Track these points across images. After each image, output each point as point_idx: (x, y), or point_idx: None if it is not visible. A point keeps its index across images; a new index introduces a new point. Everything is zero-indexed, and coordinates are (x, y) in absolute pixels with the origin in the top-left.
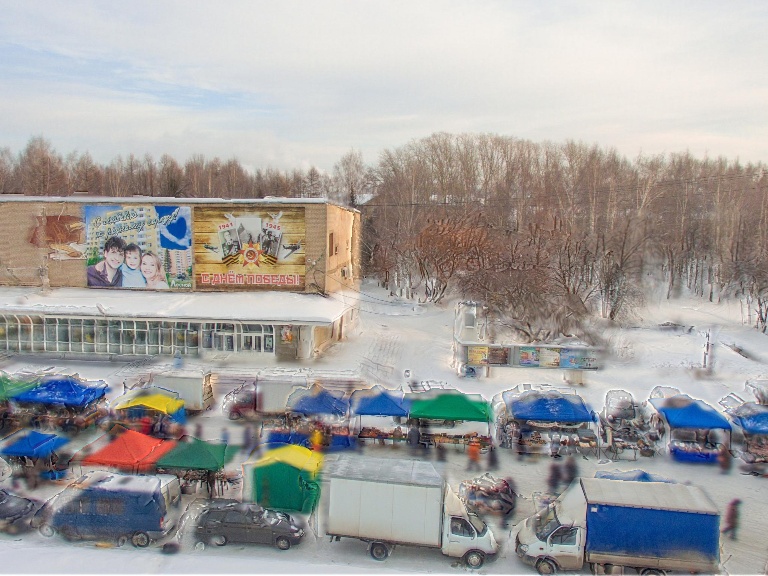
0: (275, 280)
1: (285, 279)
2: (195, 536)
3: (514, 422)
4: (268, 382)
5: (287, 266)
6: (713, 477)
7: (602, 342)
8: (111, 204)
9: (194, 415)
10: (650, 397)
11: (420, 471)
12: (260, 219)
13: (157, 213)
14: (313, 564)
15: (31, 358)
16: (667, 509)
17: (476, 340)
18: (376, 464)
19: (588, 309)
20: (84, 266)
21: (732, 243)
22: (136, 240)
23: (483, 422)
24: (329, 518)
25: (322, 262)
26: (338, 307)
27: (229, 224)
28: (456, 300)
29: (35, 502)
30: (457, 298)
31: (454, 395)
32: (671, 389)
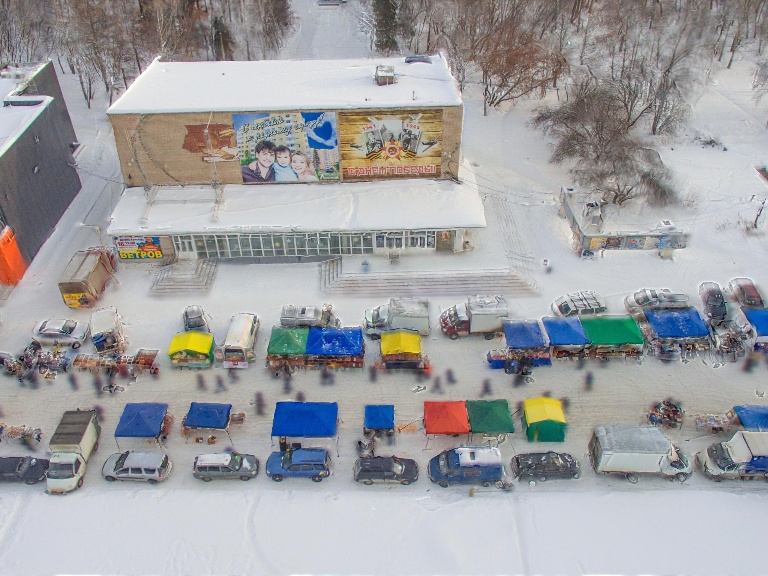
0: (414, 170)
1: (423, 169)
2: (528, 478)
3: (658, 339)
4: (480, 315)
5: (425, 158)
6: None
7: (673, 195)
8: (257, 112)
9: (425, 338)
10: (731, 285)
11: (657, 439)
12: (401, 120)
13: (303, 118)
14: (607, 495)
15: (233, 265)
16: None
17: (598, 233)
18: (630, 436)
19: (642, 125)
20: (238, 166)
21: (759, 3)
22: (285, 142)
23: (641, 344)
24: (606, 466)
25: (456, 154)
26: (478, 200)
27: (372, 125)
28: (538, 136)
29: (406, 454)
30: (539, 134)
31: (620, 325)
32: (748, 283)
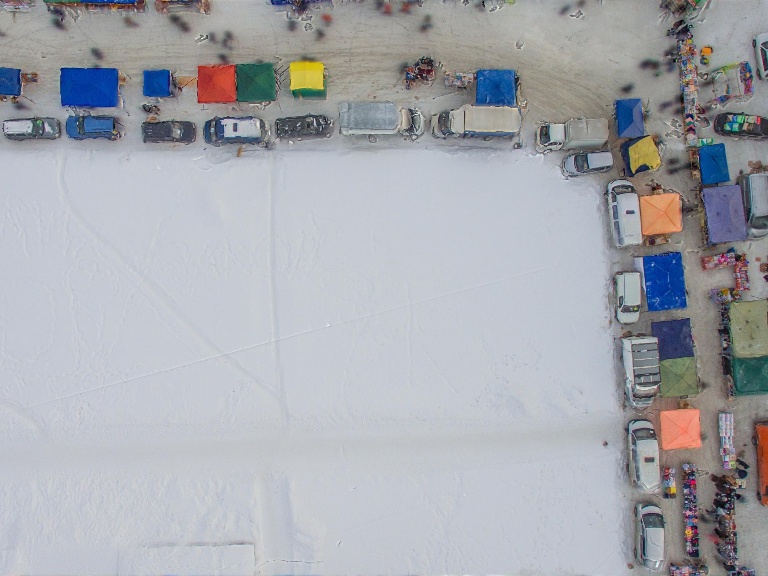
0: None
1: None
2: (287, 139)
3: None
4: None
5: None
6: (552, 25)
7: None
8: None
9: None
10: None
11: (390, 116)
12: None
13: None
14: (347, 155)
15: None
16: (498, 131)
17: None
18: (368, 112)
19: None
20: None
21: None
22: None
23: None
24: None
25: None
26: None
27: None
28: None
29: (188, 114)
30: None
31: None
32: None
